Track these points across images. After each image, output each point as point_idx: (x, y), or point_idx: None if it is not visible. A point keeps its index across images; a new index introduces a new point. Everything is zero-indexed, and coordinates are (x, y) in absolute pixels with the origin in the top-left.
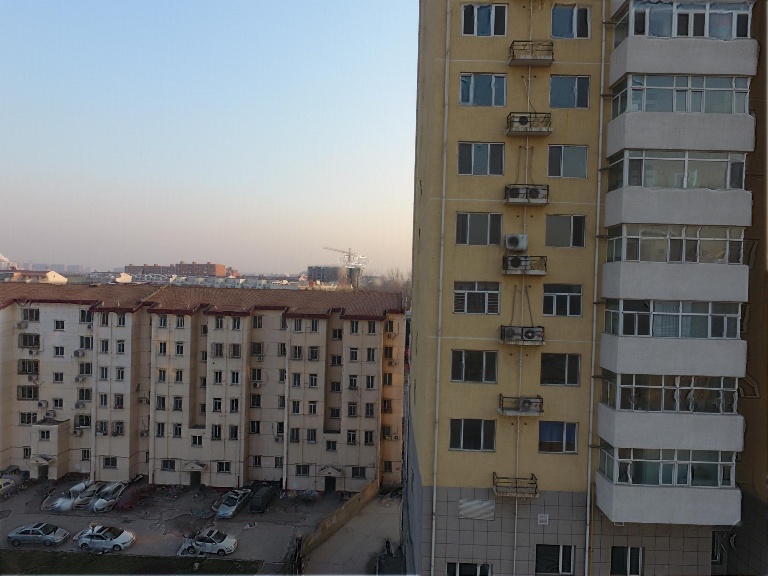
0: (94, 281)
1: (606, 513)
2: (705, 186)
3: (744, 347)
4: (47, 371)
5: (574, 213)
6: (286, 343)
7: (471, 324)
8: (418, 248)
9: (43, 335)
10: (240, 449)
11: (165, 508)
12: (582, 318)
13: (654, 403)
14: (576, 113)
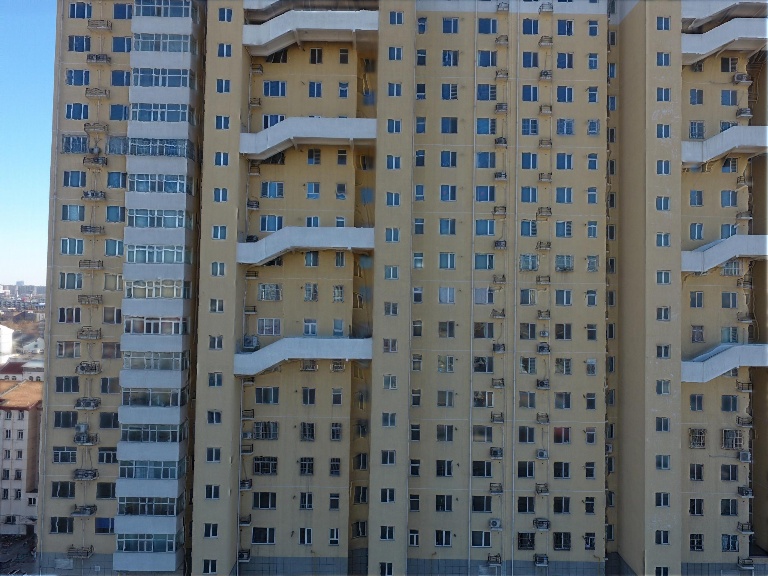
0: None
1: None
2: (164, 403)
3: (177, 483)
4: None
5: (114, 411)
6: None
7: (62, 468)
8: None
9: None
10: None
11: None
12: (118, 464)
13: (135, 511)
14: (114, 362)
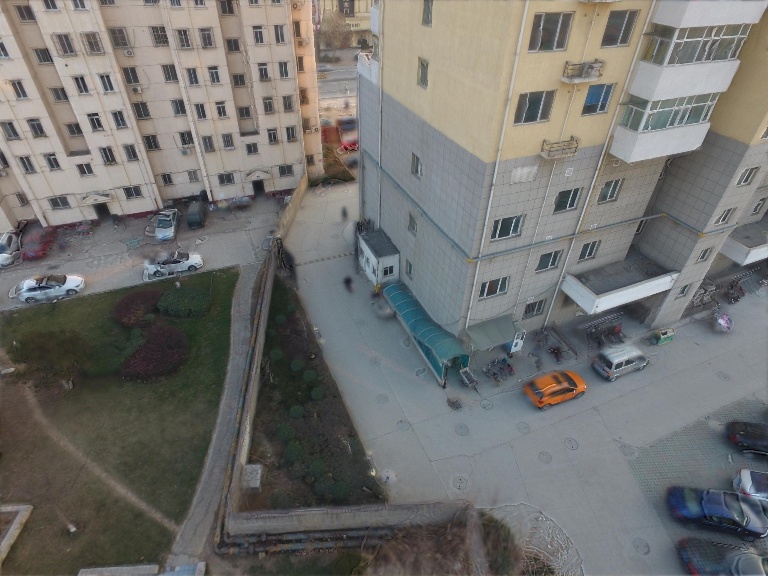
0: None
1: (622, 157)
2: None
3: None
4: None
5: None
6: (164, 26)
7: None
8: None
9: None
10: (146, 170)
11: (87, 246)
12: None
13: (691, 56)
14: None
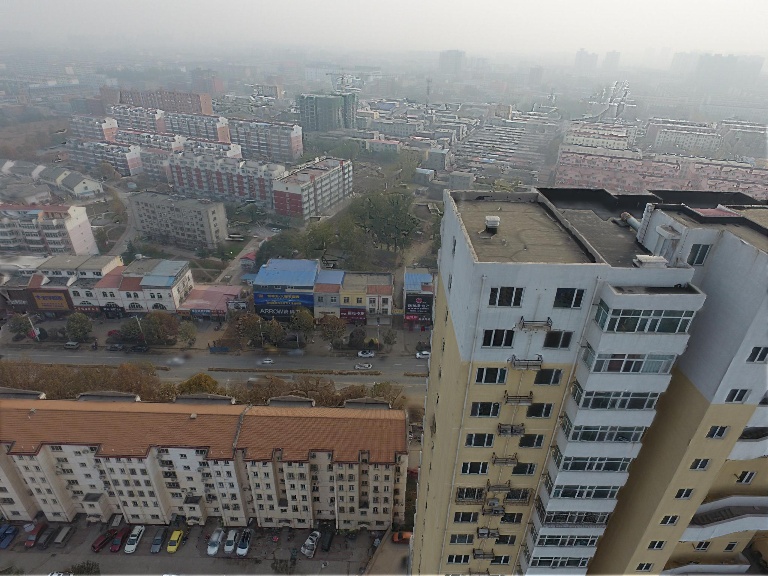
0: (79, 128)
1: None
2: None
3: None
4: (182, 476)
5: None
6: None
7: None
8: (418, 568)
9: (174, 460)
10: (310, 515)
11: (274, 548)
12: None
13: None
14: None
